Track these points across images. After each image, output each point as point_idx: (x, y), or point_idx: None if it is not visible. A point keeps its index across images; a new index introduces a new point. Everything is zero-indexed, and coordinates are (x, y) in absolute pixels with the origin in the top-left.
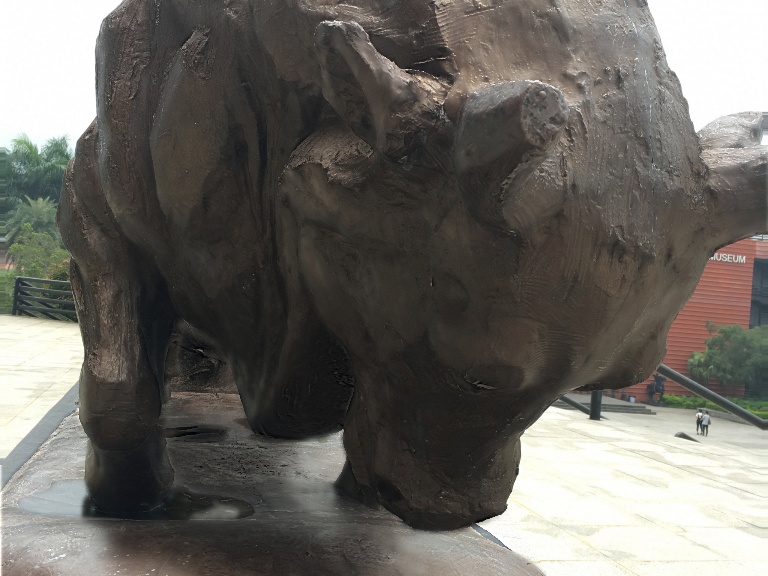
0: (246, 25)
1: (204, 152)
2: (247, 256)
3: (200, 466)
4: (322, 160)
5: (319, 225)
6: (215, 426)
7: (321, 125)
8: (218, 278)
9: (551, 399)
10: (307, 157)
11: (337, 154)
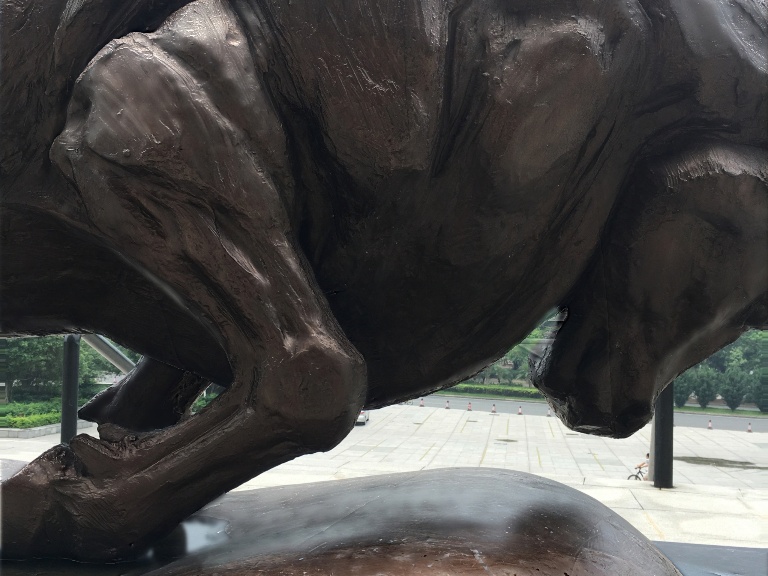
0: (646, 40)
1: (575, 132)
2: (533, 227)
3: None
4: (757, 174)
5: (702, 215)
6: None
7: None
8: (496, 246)
9: None
10: (743, 169)
11: None
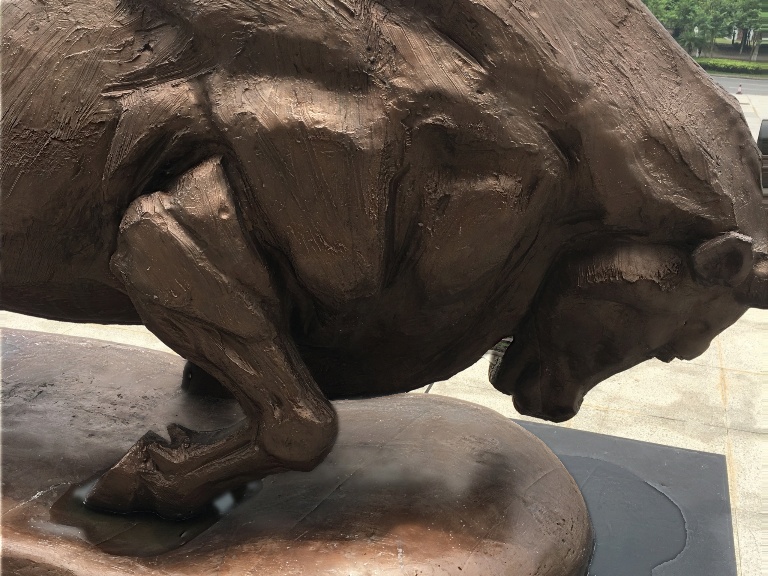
0: None
1: (496, 257)
2: None
3: (91, 435)
4: (653, 278)
5: None
6: None
7: (622, 248)
8: None
9: None
10: (640, 276)
11: (659, 273)
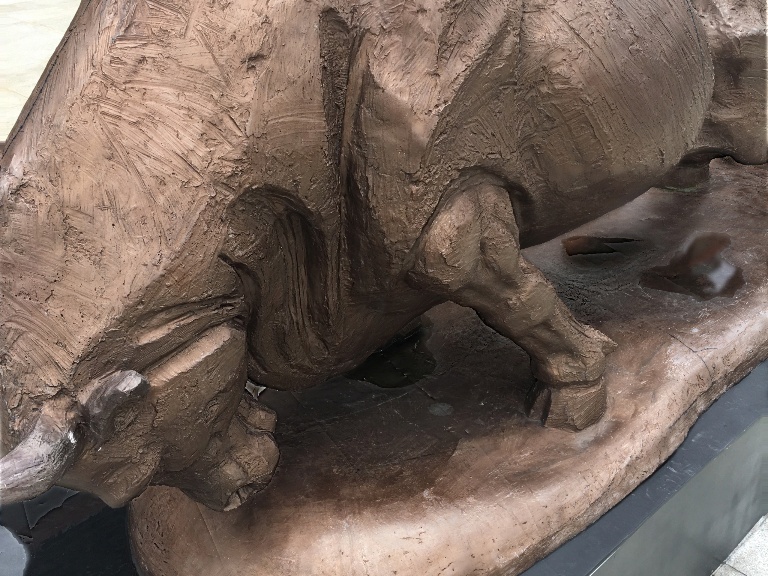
0: None
1: None
2: None
3: None
4: None
5: None
6: (652, 243)
7: None
8: None
9: None
10: None
11: None
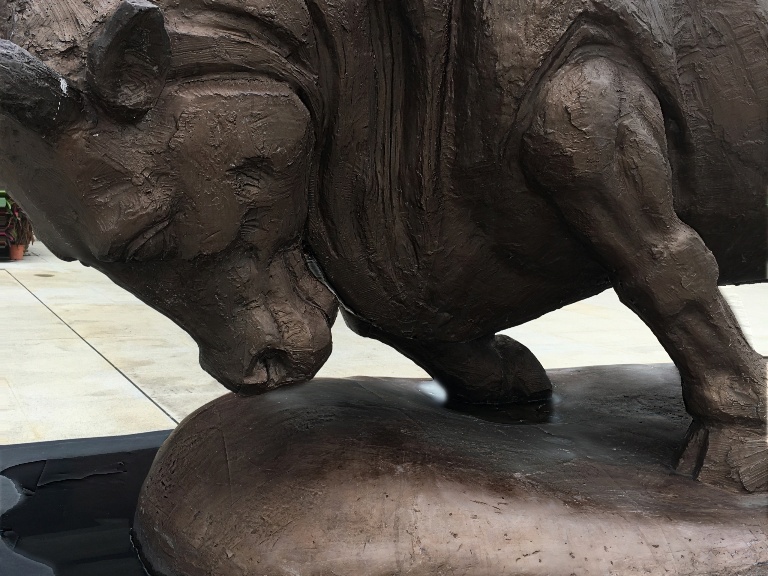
0: None
1: None
2: None
3: (626, 396)
4: None
5: None
6: None
7: None
8: None
9: (105, 271)
10: None
11: None
